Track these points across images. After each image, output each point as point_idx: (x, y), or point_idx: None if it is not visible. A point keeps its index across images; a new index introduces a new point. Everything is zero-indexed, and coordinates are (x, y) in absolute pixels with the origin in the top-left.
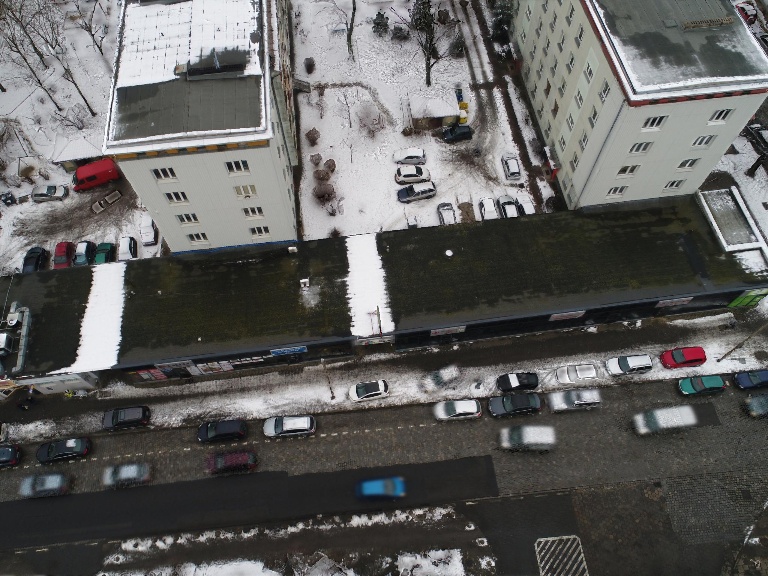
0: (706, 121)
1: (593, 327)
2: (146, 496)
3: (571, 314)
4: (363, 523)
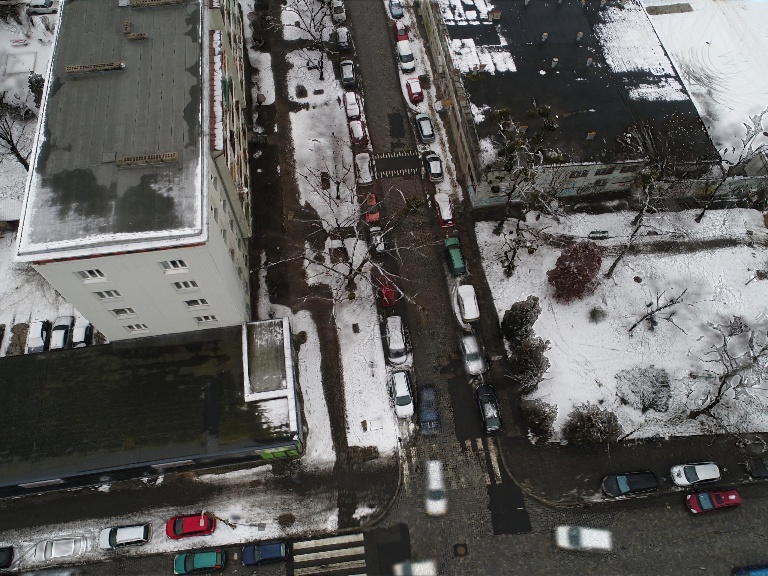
0: (159, 271)
1: (106, 485)
2: None
3: (46, 482)
4: None
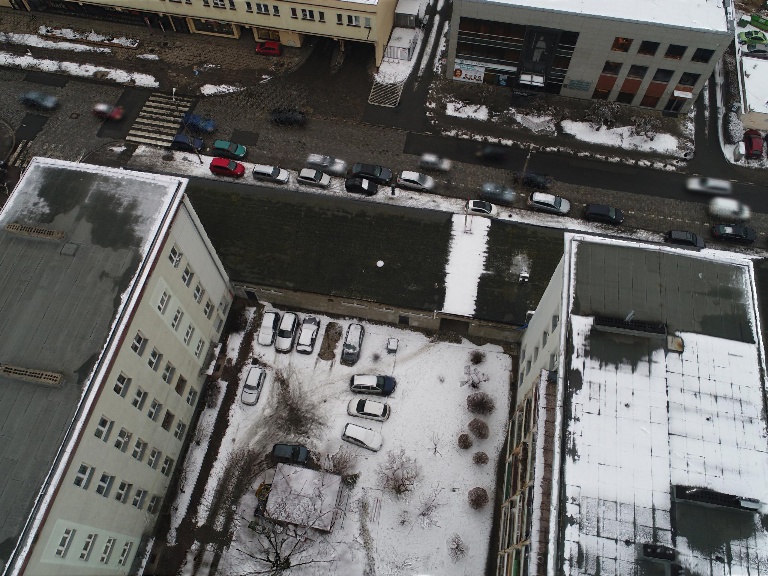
0: None
1: None
2: (661, 191)
3: None
4: (505, 140)
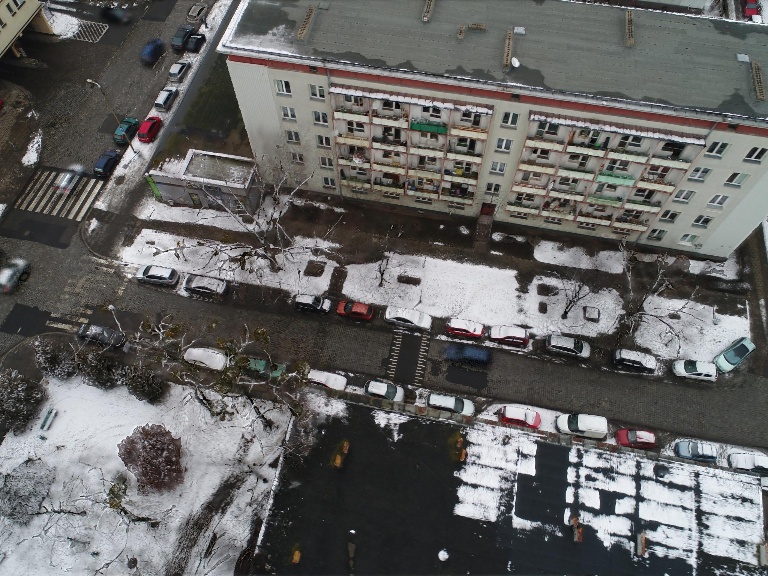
0: None
1: None
2: None
3: None
4: None
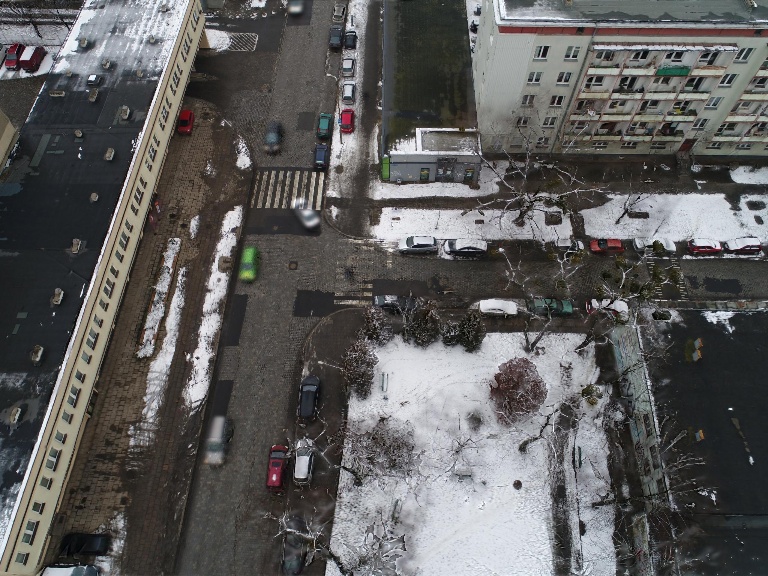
0: None
1: None
2: None
3: None
4: None
